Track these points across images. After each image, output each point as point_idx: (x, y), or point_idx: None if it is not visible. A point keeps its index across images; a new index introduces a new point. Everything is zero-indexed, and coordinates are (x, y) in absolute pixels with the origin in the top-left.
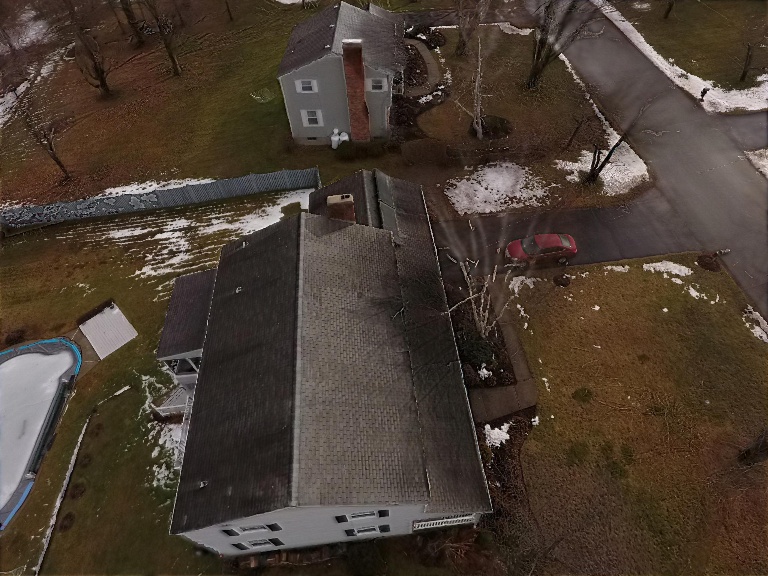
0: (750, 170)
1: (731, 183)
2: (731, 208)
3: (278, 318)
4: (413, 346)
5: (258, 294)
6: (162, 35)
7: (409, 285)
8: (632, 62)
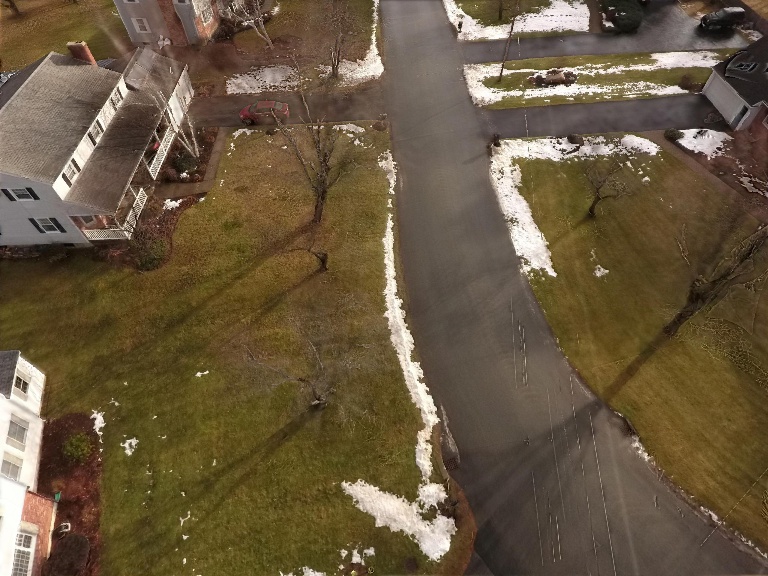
0: (458, 76)
1: (436, 83)
2: (423, 97)
3: (6, 99)
4: (111, 137)
5: (7, 92)
6: None
7: (131, 110)
8: (428, 5)
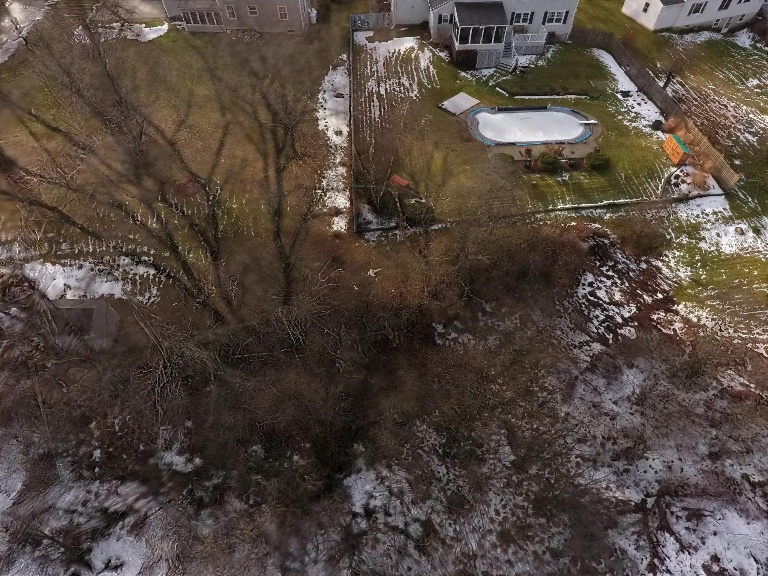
0: None
1: None
2: None
3: None
4: None
5: None
6: (109, 76)
7: None
8: None
